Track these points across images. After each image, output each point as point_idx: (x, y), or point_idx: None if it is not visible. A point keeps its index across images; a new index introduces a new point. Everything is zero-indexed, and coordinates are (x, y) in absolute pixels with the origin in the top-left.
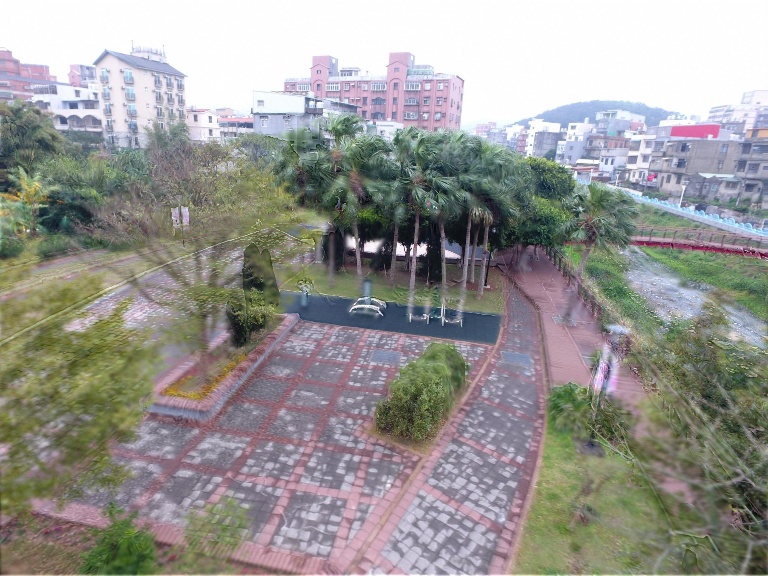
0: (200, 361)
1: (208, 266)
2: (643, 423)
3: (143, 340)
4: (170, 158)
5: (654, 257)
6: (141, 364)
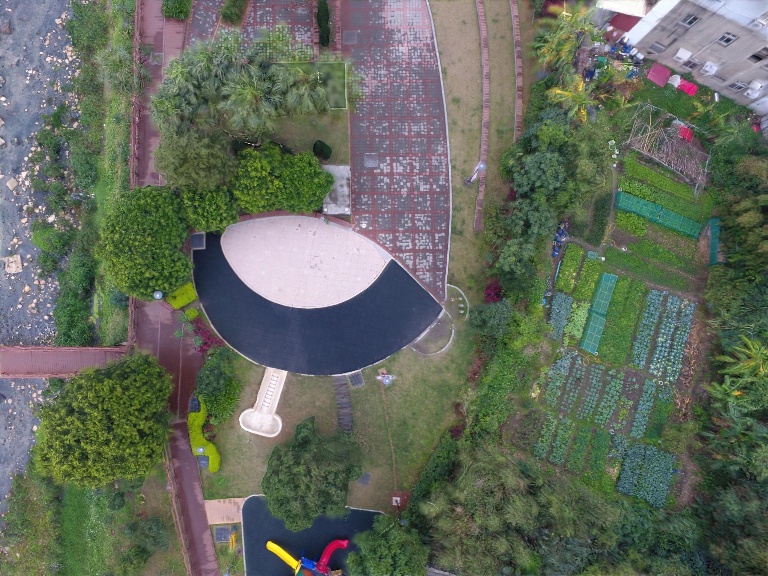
0: (335, 1)
1: (419, 140)
2: (154, 12)
3: (376, 21)
4: (759, 518)
5: (6, 346)
6: (361, 2)
